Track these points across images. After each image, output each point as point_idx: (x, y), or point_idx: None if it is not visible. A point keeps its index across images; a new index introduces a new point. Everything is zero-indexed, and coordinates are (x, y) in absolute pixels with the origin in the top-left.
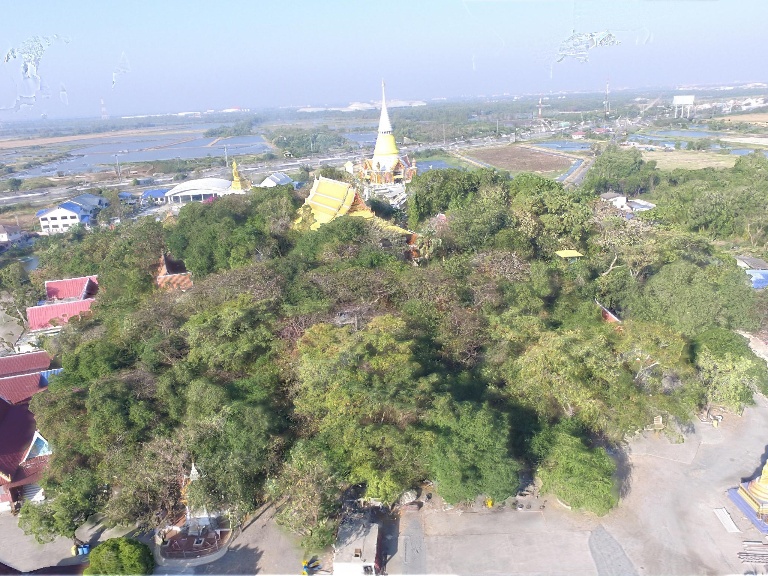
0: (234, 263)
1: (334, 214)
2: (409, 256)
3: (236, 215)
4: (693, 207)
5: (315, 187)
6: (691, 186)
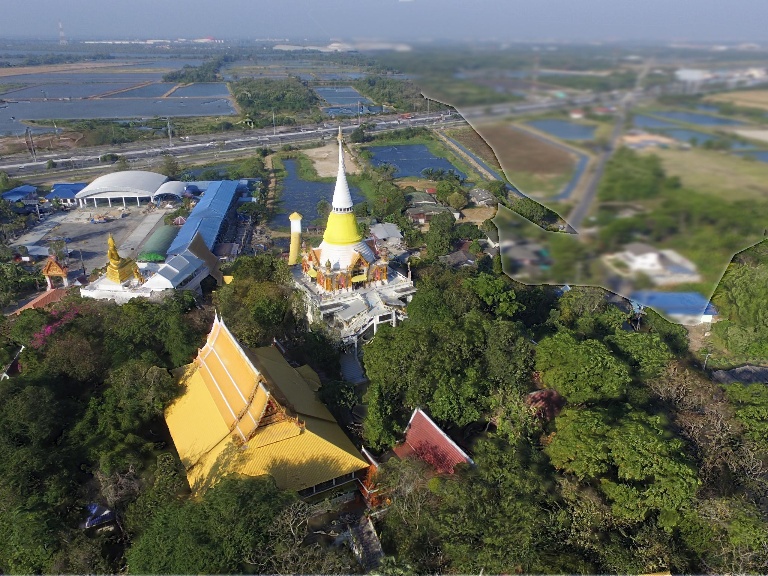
0: (17, 570)
1: (231, 426)
2: (362, 498)
3: (77, 380)
4: (767, 310)
5: (214, 333)
6: (765, 277)
